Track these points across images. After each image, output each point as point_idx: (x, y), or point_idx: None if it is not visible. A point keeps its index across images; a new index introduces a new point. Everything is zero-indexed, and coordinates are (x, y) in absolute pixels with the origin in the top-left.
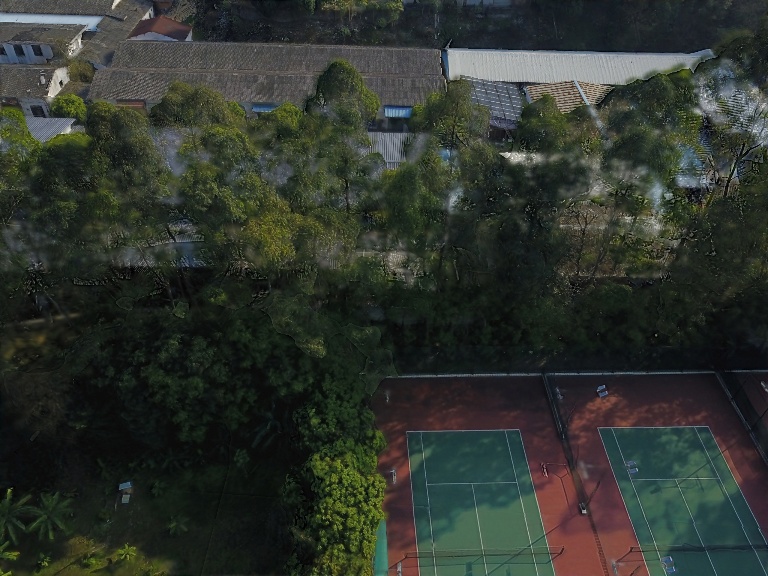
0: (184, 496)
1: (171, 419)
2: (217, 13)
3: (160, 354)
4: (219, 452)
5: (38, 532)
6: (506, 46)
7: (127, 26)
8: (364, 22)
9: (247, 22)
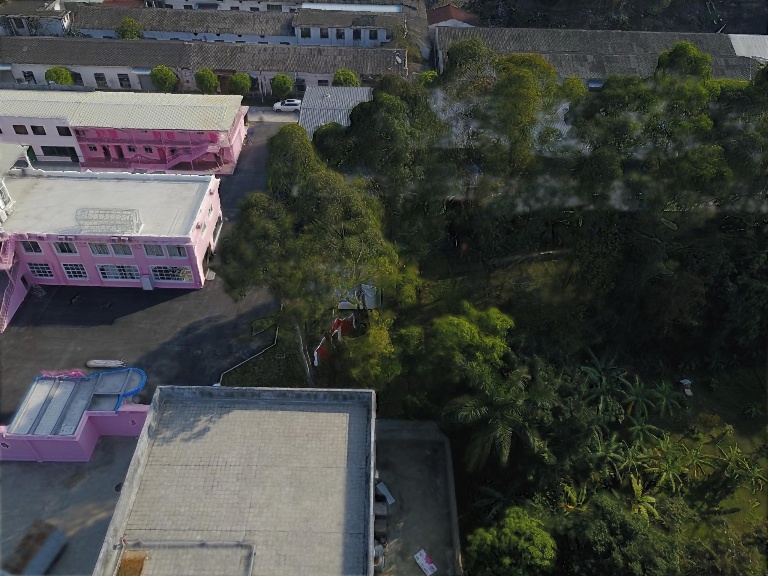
0: (735, 391)
1: (744, 322)
2: (494, 3)
3: (754, 265)
4: (751, 356)
5: (660, 411)
6: (762, 32)
7: (422, 14)
8: (633, 10)
9: (525, 11)
